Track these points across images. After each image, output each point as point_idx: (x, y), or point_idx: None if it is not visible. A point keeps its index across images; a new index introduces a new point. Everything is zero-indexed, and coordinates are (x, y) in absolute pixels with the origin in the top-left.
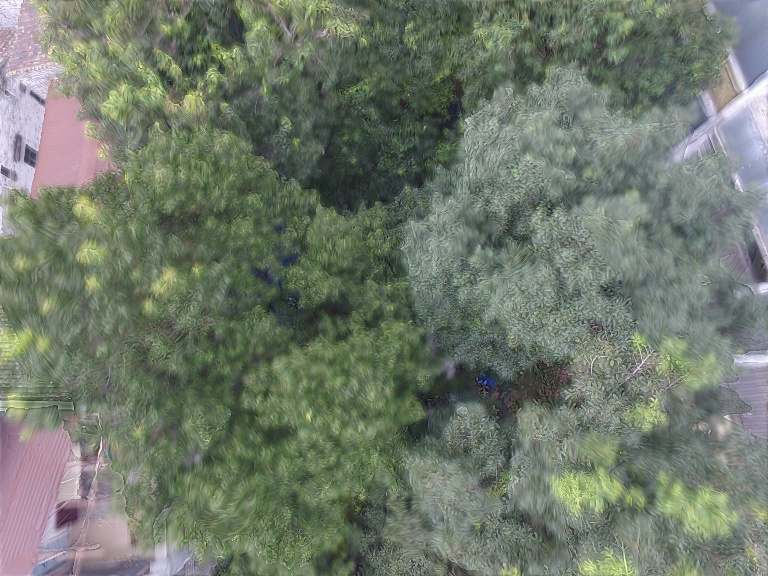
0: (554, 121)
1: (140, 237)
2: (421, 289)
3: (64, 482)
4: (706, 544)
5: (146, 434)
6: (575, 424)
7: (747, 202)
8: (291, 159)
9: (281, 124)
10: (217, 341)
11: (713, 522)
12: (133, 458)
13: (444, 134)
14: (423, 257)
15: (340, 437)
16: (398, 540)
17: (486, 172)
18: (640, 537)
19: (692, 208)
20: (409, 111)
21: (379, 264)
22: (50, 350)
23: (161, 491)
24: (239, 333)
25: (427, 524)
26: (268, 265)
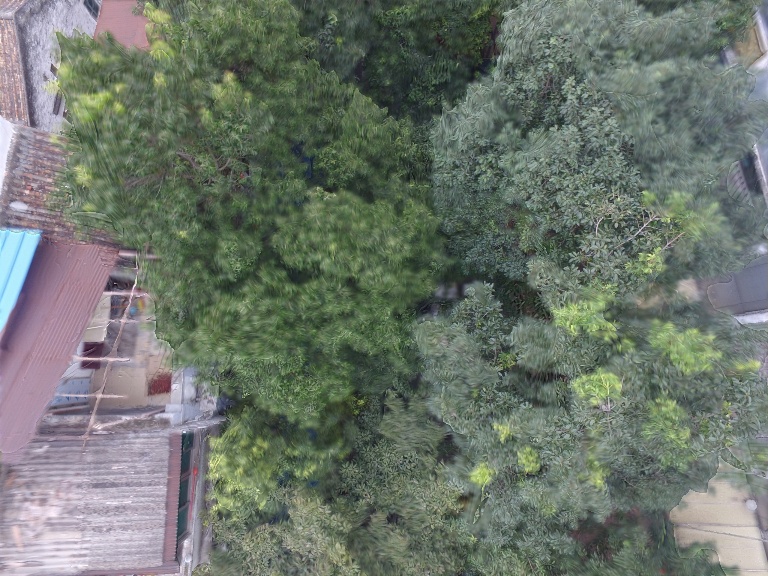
0: (587, 6)
1: (200, 69)
2: (443, 181)
3: (93, 328)
4: (684, 378)
5: (184, 254)
6: (576, 282)
7: (758, 110)
8: (332, 60)
9: (328, 20)
10: (251, 198)
11: (693, 355)
12: (170, 275)
13: (475, 77)
14: (450, 138)
15: (357, 286)
16: (392, 437)
17: (518, 55)
18: (625, 378)
19: (706, 102)
20: (444, 48)
21: (404, 169)
22: (115, 144)
23: (187, 324)
24: (272, 193)
25: (421, 424)
26: (304, 140)
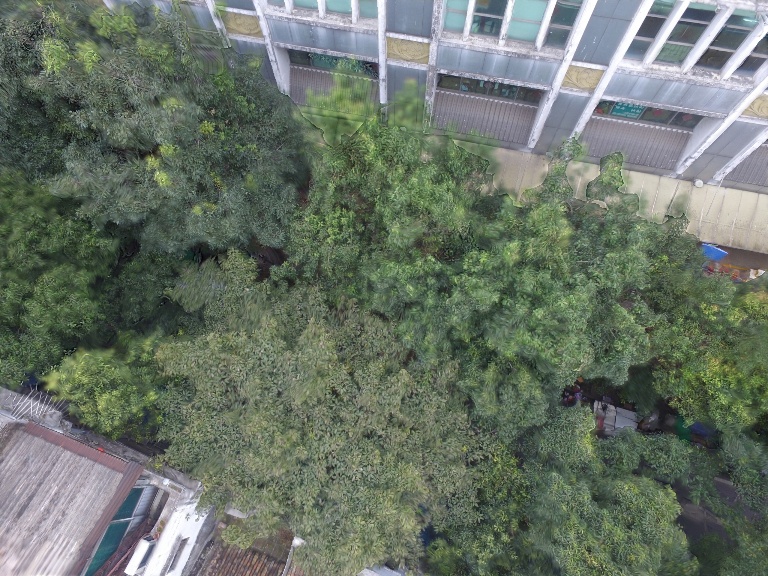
0: None
1: None
2: None
3: None
4: (118, 34)
5: None
6: None
7: None
8: None
9: None
10: None
11: None
12: None
13: None
14: None
15: None
16: (201, 305)
17: None
18: None
19: None
20: None
21: None
22: None
23: None
24: None
25: None
26: None
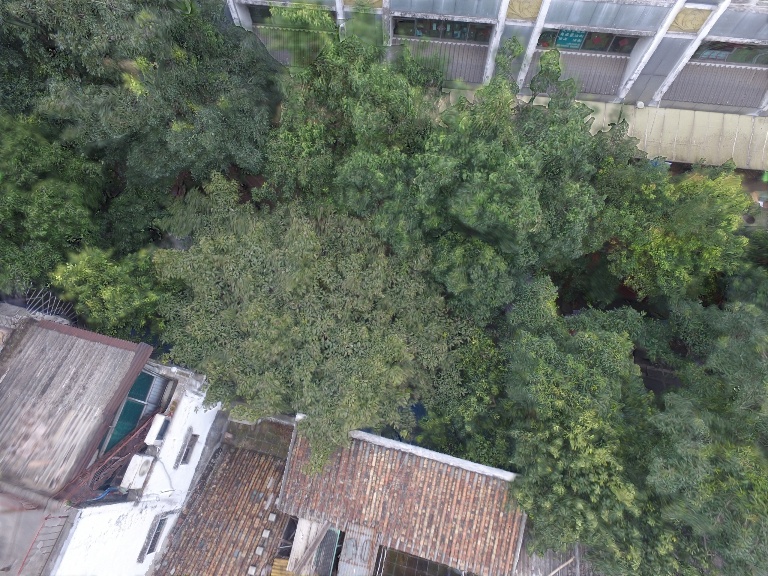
0: None
1: None
2: None
3: None
4: None
5: None
6: None
7: None
8: None
9: None
10: None
11: None
12: None
13: None
14: None
15: None
16: (190, 232)
17: None
18: None
19: None
20: None
21: None
22: None
23: None
24: None
25: (187, 207)
26: None
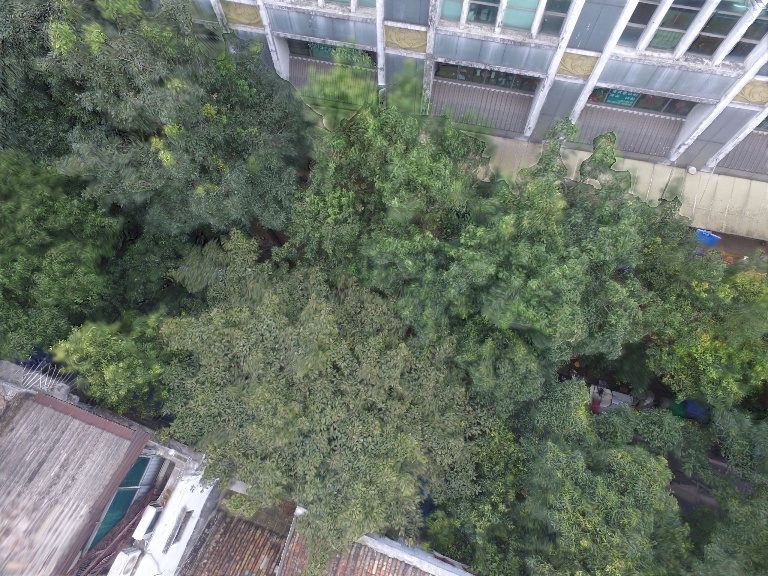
0: None
1: None
2: None
3: None
4: (124, 15)
5: None
6: None
7: None
8: None
9: None
10: None
11: None
12: None
13: None
14: None
15: None
16: (204, 286)
17: None
18: None
19: None
20: None
21: None
22: None
23: None
24: None
25: (203, 259)
26: None
